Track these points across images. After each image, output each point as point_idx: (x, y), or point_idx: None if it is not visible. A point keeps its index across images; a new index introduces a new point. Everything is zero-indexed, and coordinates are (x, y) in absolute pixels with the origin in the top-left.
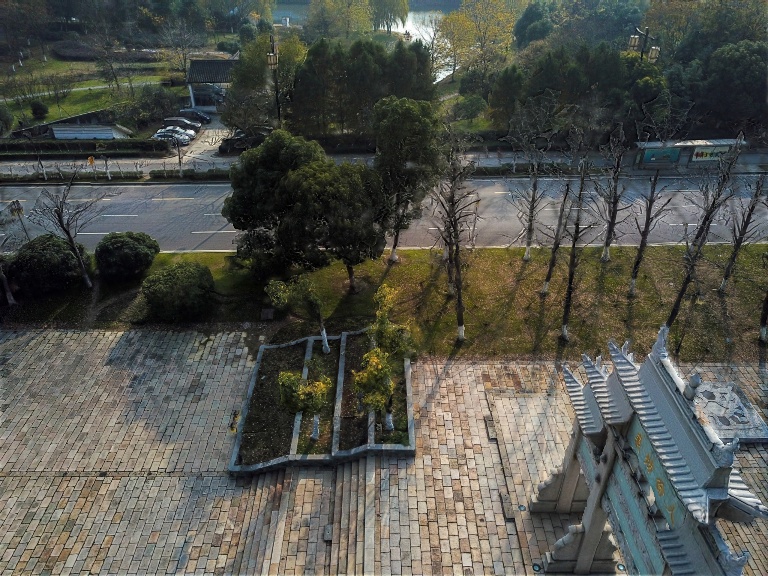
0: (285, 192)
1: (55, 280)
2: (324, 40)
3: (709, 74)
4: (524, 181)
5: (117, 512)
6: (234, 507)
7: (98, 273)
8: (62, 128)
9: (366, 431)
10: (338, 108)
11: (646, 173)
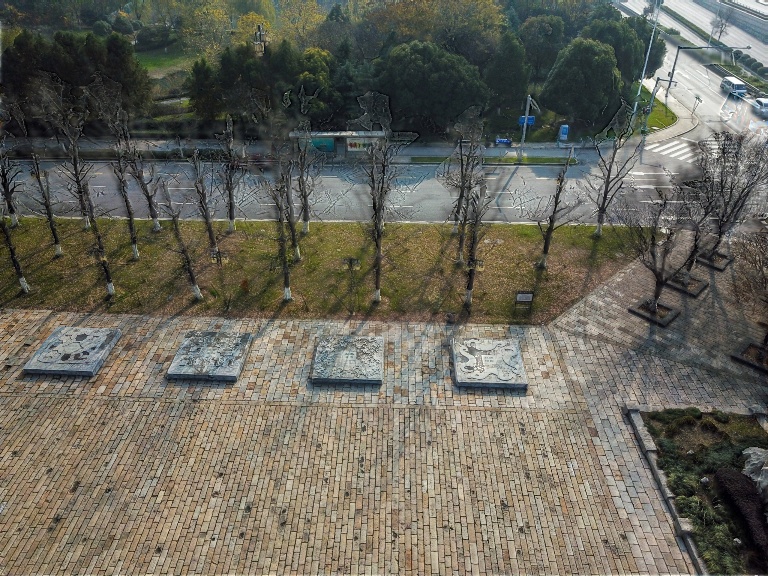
0: None
1: None
2: (27, 31)
3: (383, 71)
4: (183, 164)
5: None
6: None
7: None
8: None
9: None
10: None
11: None
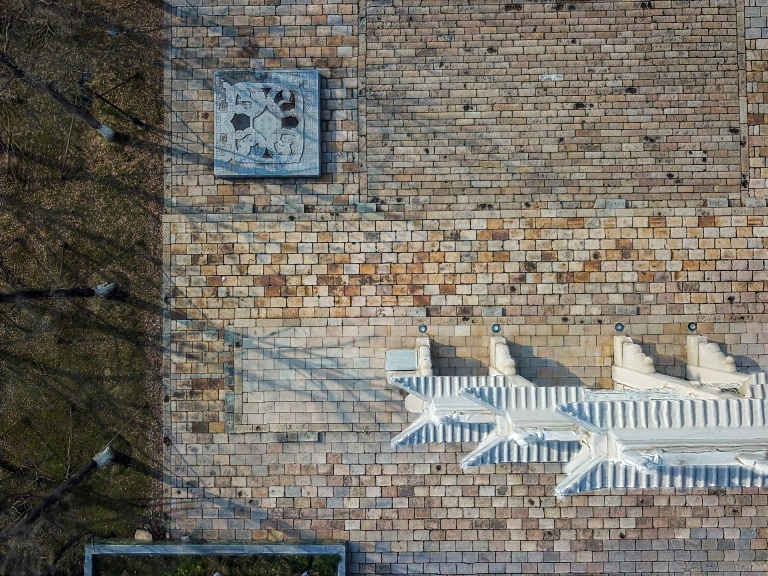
0: None
1: None
2: None
3: None
4: None
5: None
6: None
7: None
8: None
9: None
10: None
11: None
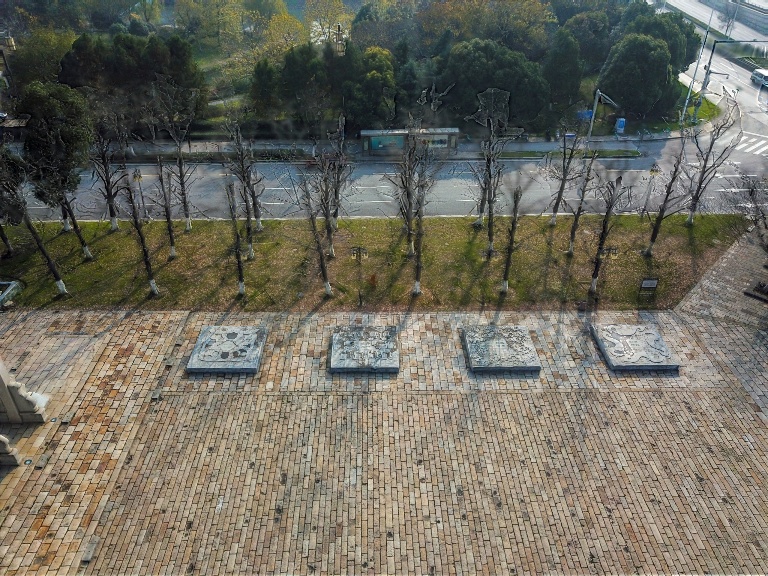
0: None
1: None
2: (86, 34)
3: (444, 69)
4: (256, 165)
5: None
6: None
7: None
8: None
9: None
10: None
11: (371, 159)
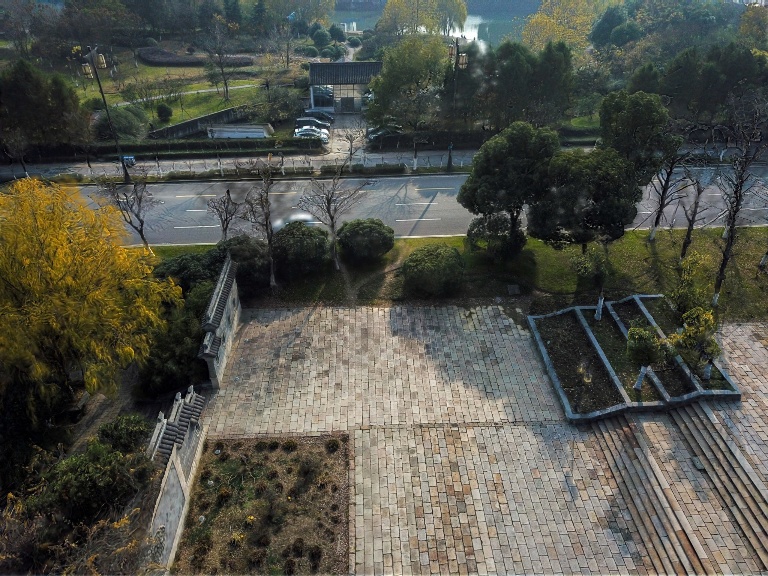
0: (546, 177)
1: (312, 263)
2: (475, 42)
3: None
4: (675, 170)
5: (489, 455)
6: (589, 448)
7: (338, 257)
8: (217, 128)
9: (689, 380)
10: (485, 106)
11: None
